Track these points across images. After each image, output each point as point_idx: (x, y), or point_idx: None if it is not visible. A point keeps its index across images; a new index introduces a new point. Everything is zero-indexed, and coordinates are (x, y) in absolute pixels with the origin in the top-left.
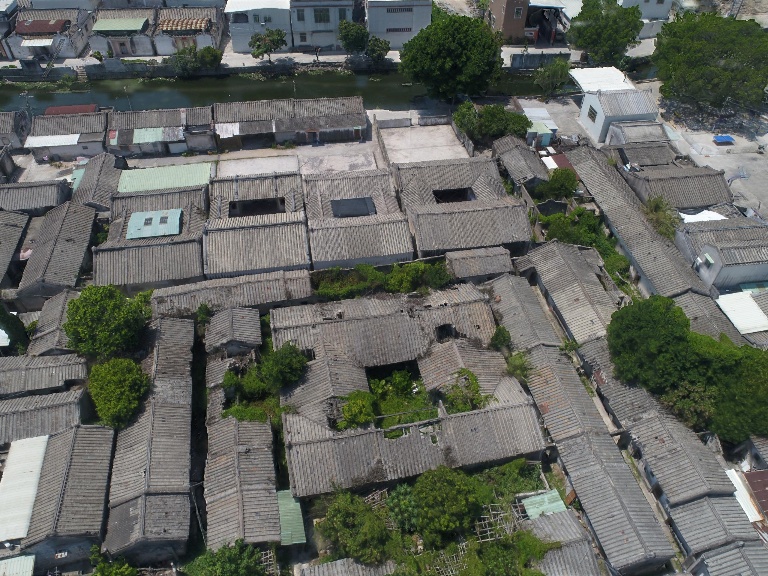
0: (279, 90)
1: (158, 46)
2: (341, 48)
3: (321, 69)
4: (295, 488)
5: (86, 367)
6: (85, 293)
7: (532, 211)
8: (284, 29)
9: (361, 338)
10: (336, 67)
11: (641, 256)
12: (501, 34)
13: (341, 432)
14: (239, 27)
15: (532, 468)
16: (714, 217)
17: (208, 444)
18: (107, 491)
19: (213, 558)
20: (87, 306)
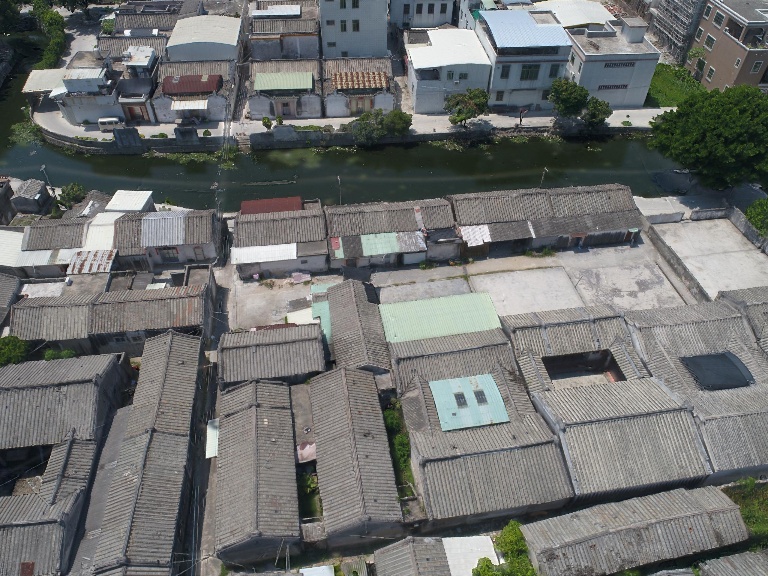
0: (487, 165)
1: (328, 107)
2: (553, 111)
3: (524, 135)
4: None
5: None
6: None
7: None
8: (480, 87)
9: None
10: (541, 132)
11: None
12: None
13: None
14: (428, 85)
15: None
16: None
17: None
18: None
19: None
20: None
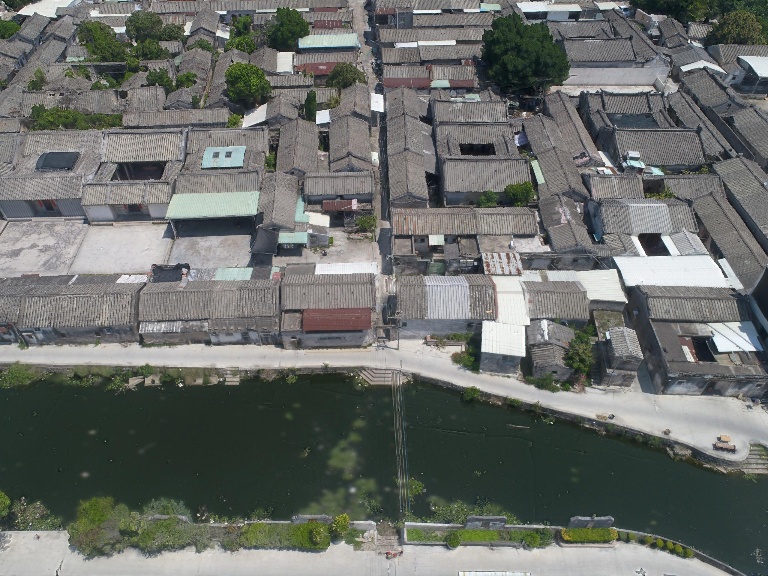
0: (10, 456)
1: None
2: None
3: None
4: None
5: None
6: None
7: None
8: None
9: None
10: None
11: None
12: None
13: (144, 64)
14: None
15: None
16: None
17: None
18: None
19: (208, 46)
20: None
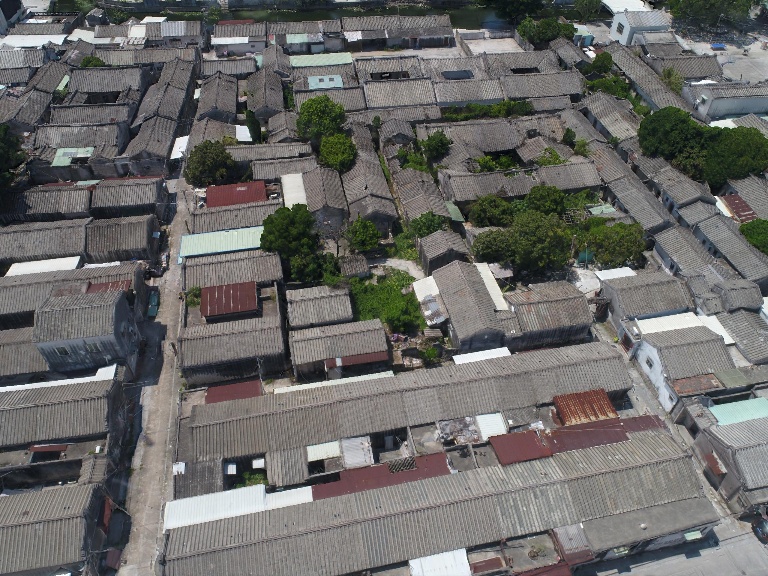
0: None
1: None
2: None
3: (406, 5)
4: (455, 197)
5: (311, 146)
6: (309, 101)
7: None
8: None
9: (480, 135)
10: (418, 3)
11: (658, 101)
12: None
13: (478, 173)
14: None
15: (594, 196)
16: (709, 82)
17: (396, 182)
18: (345, 197)
19: None
20: (316, 104)
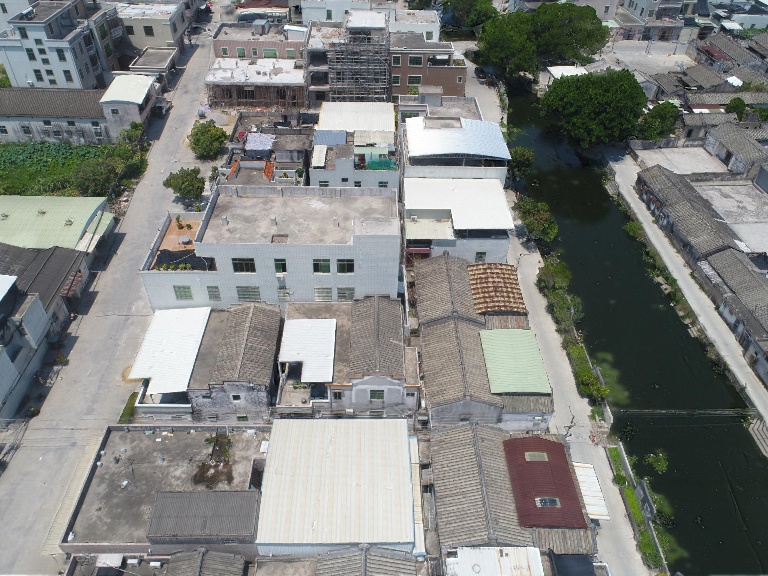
0: (581, 242)
1: None
2: None
3: None
4: None
5: None
6: None
7: (759, 127)
8: None
9: None
10: None
11: None
12: (574, 76)
13: None
14: None
15: None
16: (734, 79)
17: None
18: None
19: None
20: None
